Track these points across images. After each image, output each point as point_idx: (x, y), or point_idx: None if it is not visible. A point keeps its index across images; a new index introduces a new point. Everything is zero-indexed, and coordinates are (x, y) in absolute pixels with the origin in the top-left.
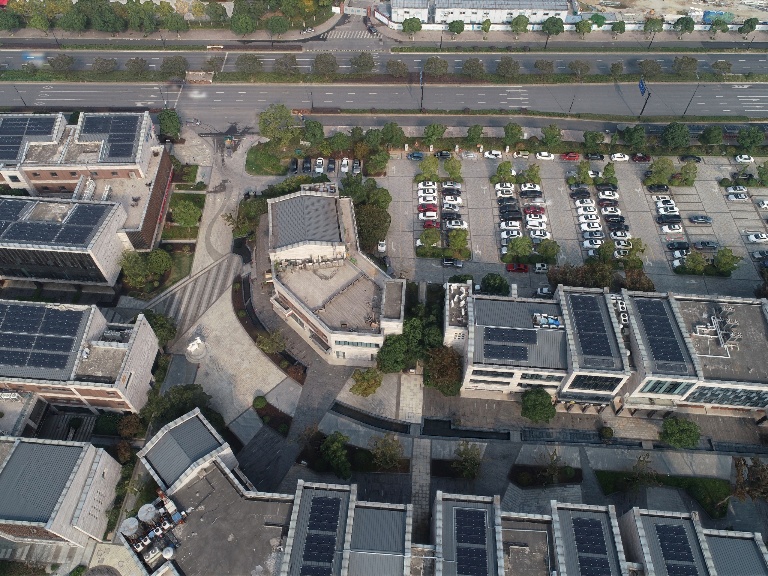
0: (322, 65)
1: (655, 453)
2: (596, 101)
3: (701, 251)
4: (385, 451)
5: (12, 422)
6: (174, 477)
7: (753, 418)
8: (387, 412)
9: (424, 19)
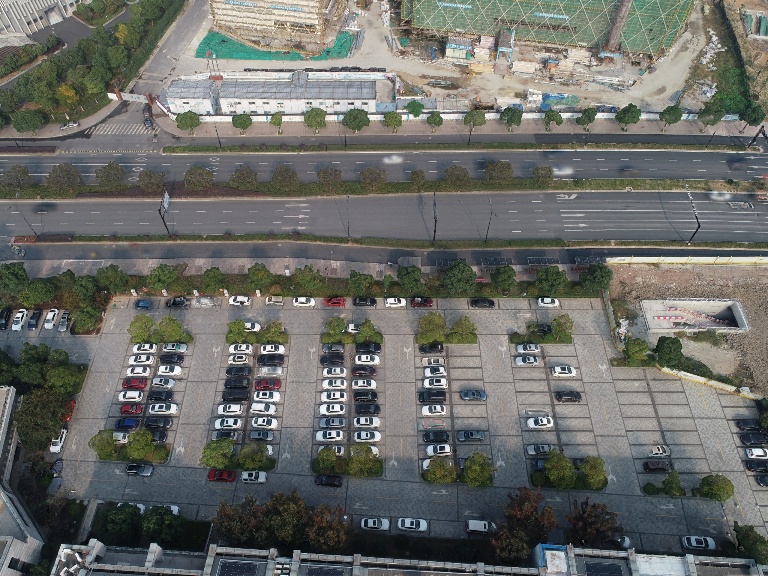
0: (56, 180)
1: None
2: (389, 219)
3: (464, 443)
4: None
5: None
6: None
7: None
8: None
9: (209, 110)
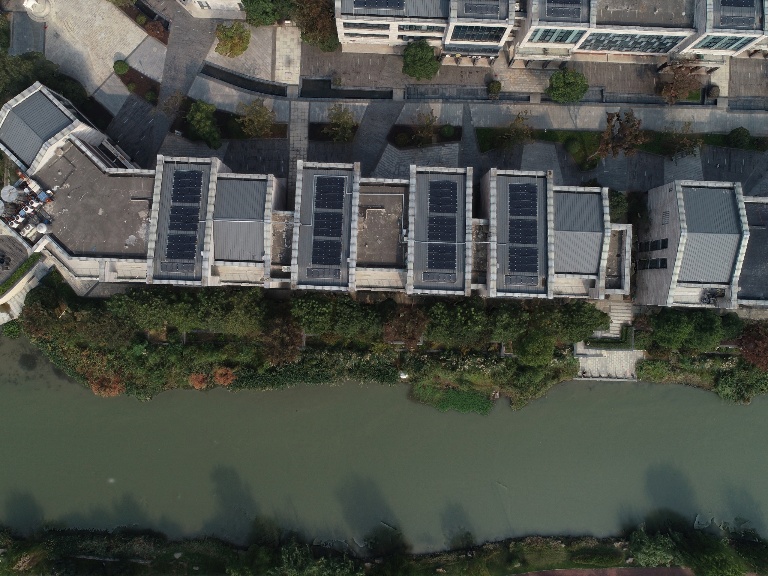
0: None
1: (541, 107)
2: None
3: None
4: (252, 119)
5: None
6: (31, 157)
7: (656, 64)
8: (262, 73)
9: None
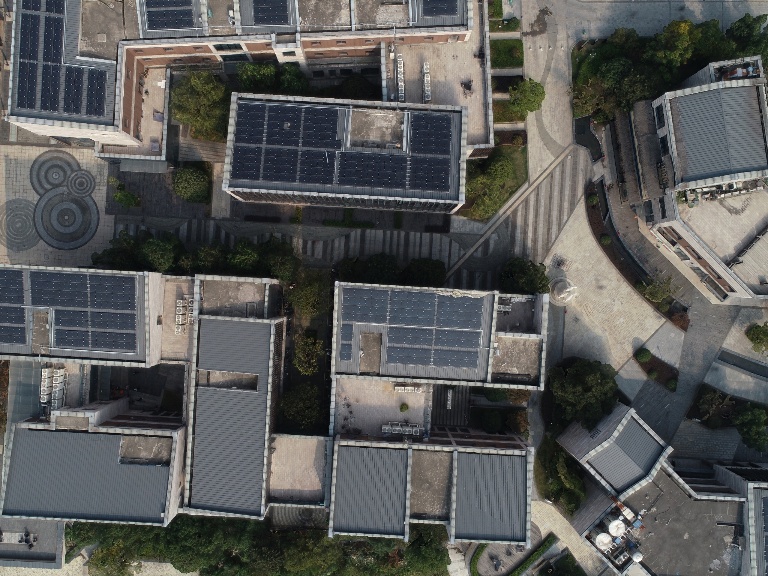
0: None
1: None
2: None
3: None
4: None
5: (420, 414)
6: (623, 483)
7: None
8: None
9: None
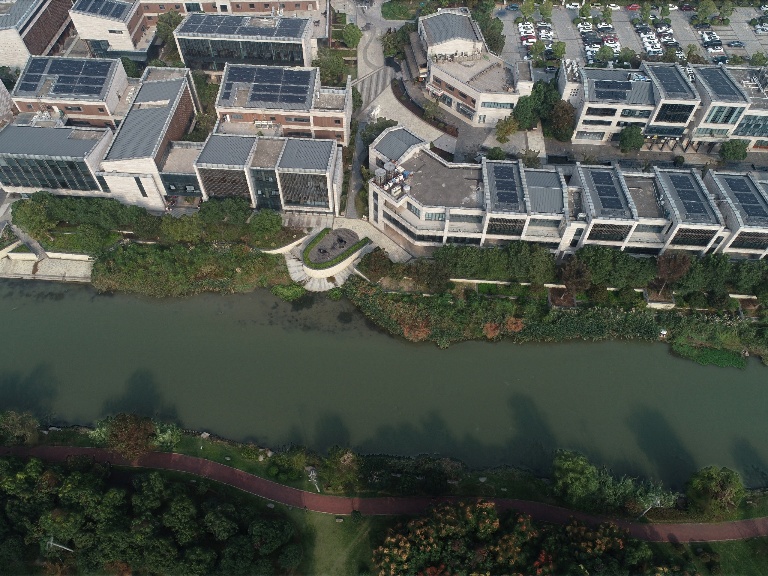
0: None
1: None
2: None
3: None
4: (531, 157)
5: None
6: (398, 157)
7: None
8: None
9: None
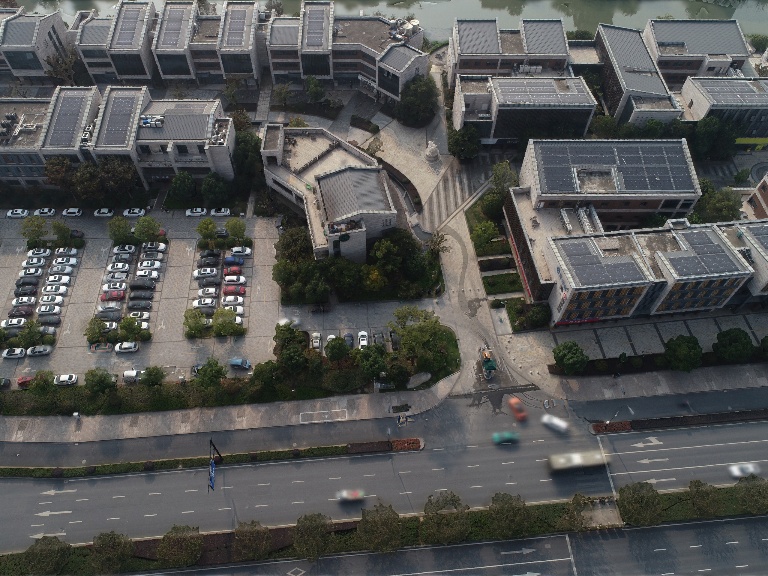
0: (384, 516)
1: None
2: None
3: None
4: None
5: None
6: None
7: None
8: None
9: None
